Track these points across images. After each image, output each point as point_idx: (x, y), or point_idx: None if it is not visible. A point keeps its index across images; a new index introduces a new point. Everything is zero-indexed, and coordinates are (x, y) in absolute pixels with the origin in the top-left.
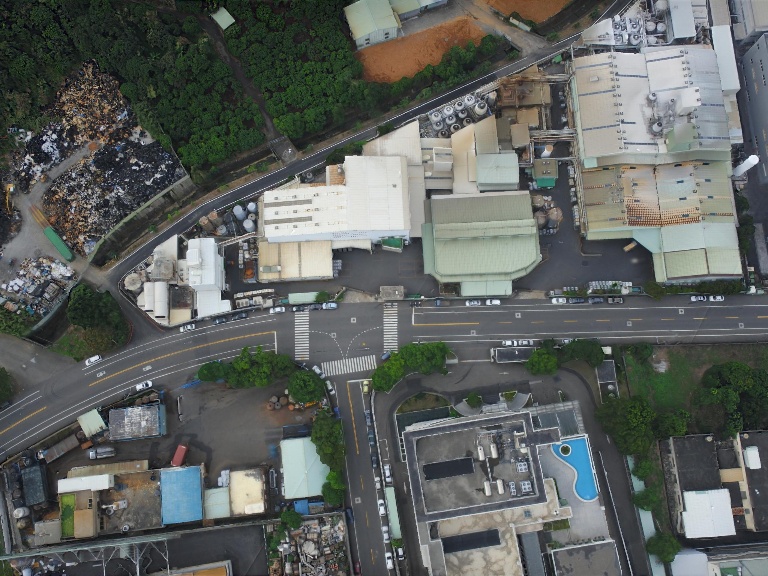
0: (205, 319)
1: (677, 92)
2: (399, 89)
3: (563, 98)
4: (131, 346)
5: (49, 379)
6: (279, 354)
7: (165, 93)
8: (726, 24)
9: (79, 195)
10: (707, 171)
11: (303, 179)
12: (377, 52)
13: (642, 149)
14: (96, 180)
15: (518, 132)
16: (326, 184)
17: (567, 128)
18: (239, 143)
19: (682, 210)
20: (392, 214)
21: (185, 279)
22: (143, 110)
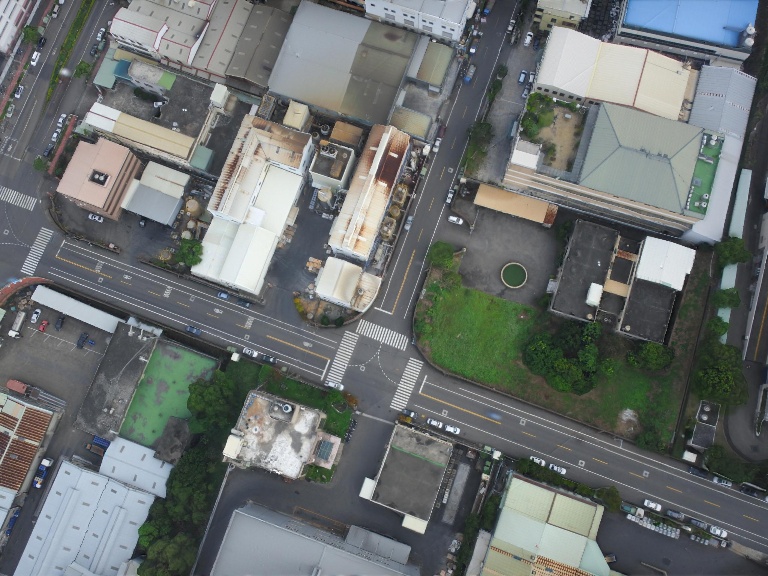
0: None
1: None
2: None
3: None
4: None
5: None
6: None
7: None
8: None
9: None
10: None
11: None
12: None
13: None
14: None
15: None
16: None
17: None
18: None
19: None
20: None
21: None
22: None
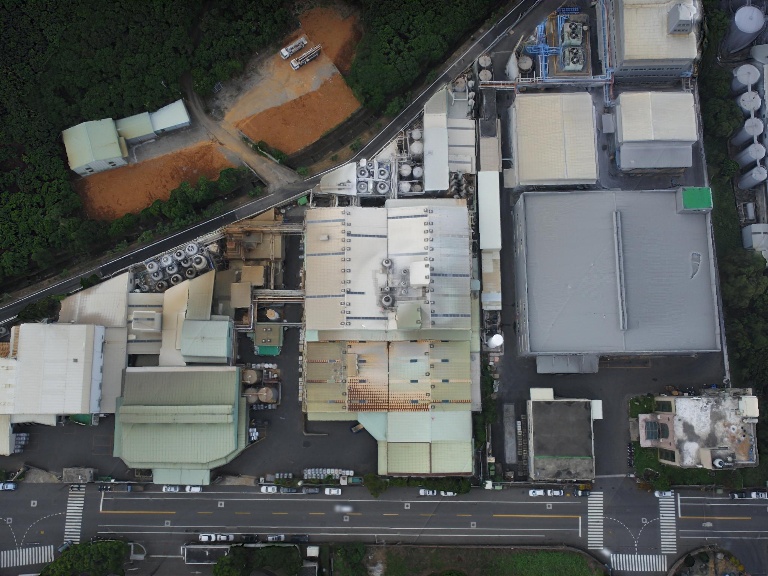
0: None
1: (415, 258)
2: (118, 230)
3: (302, 249)
4: None
5: None
6: None
7: None
8: (495, 170)
9: None
10: (446, 349)
11: None
12: (104, 180)
13: (368, 324)
14: None
15: (238, 292)
16: None
17: (298, 287)
18: None
19: (412, 394)
20: (69, 394)
21: None
22: None
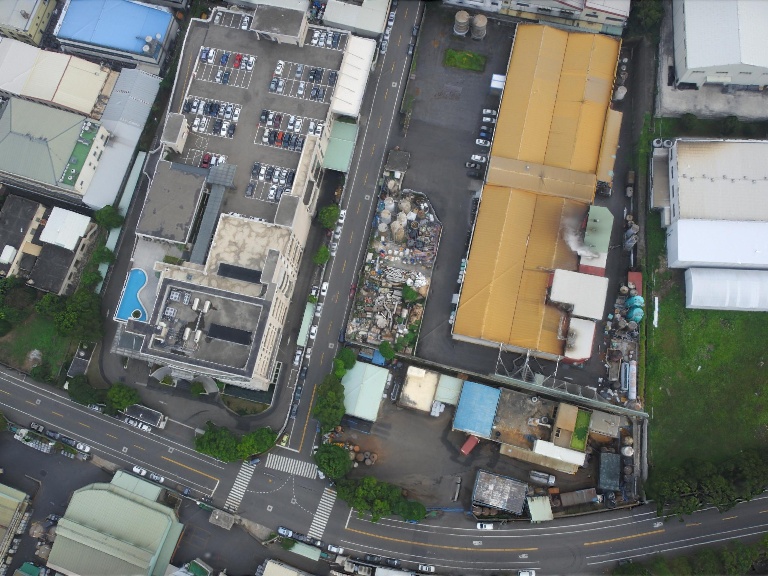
0: (407, 570)
1: None
2: None
3: None
4: (487, 573)
5: (575, 573)
6: None
7: None
8: None
9: None
10: None
11: None
12: None
13: None
14: None
15: None
16: None
17: None
18: None
19: None
20: None
21: None
22: None
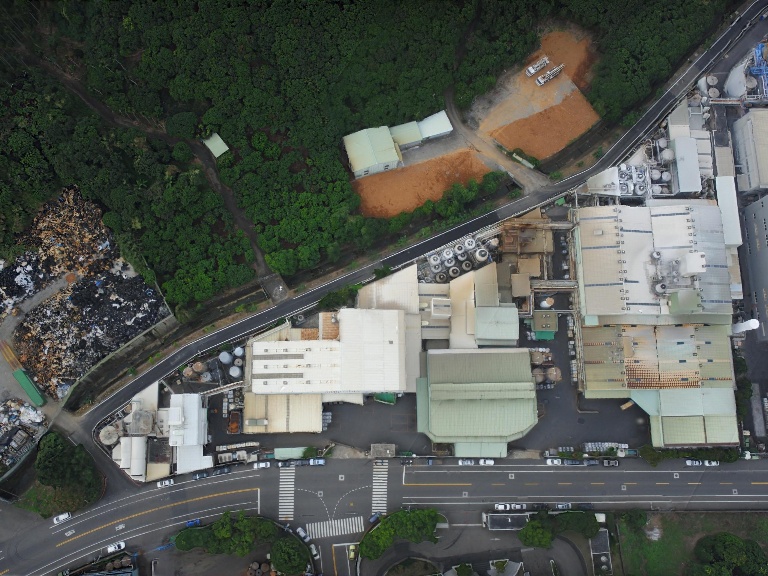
0: (184, 473)
1: (681, 251)
2: (397, 226)
3: (565, 244)
4: (104, 502)
5: (13, 538)
6: (262, 518)
7: (151, 225)
8: (730, 175)
9: (54, 334)
10: (708, 333)
11: (294, 321)
12: (375, 182)
13: (644, 310)
14: (73, 318)
15: (519, 282)
16: (319, 333)
17: (568, 278)
18: (228, 280)
19: (681, 373)
20: (387, 373)
21: (165, 432)
22: (127, 242)
